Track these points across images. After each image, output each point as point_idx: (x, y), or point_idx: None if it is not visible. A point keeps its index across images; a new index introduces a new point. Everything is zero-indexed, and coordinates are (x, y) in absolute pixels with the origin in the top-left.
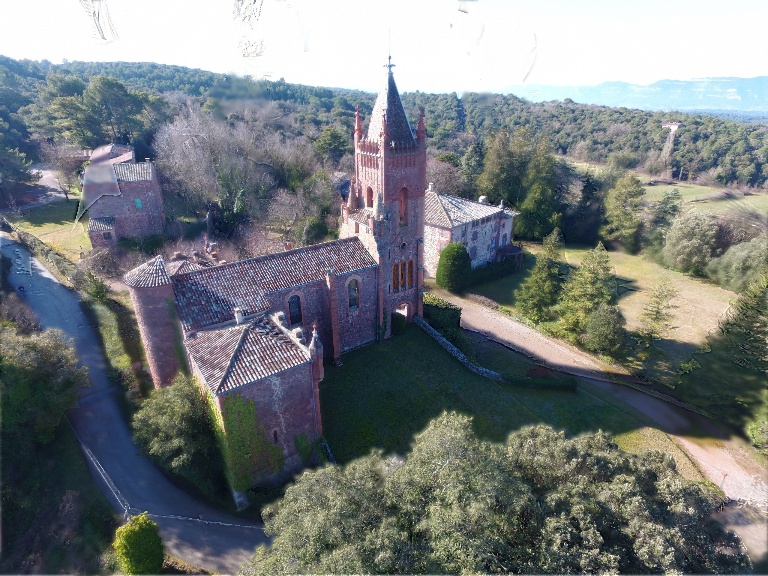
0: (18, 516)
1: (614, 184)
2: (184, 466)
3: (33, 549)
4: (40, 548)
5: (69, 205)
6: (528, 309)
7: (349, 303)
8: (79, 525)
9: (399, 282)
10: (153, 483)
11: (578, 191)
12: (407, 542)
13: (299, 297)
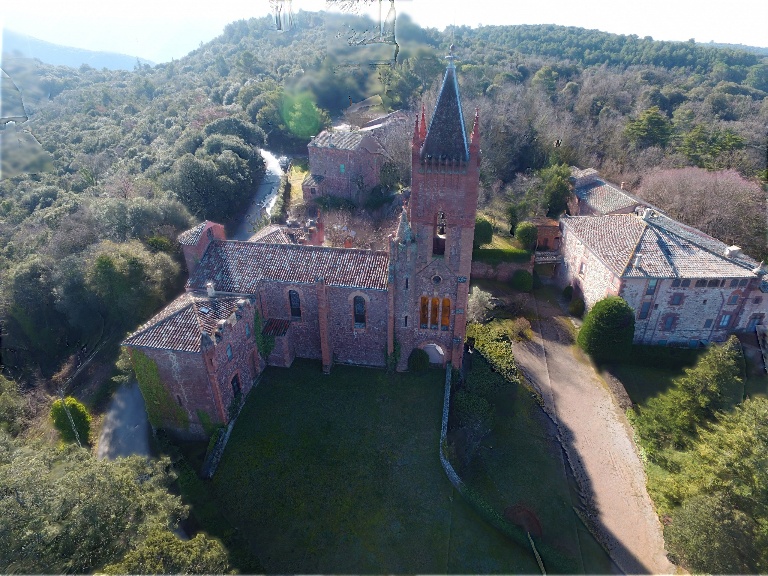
0: None
1: None
2: (129, 384)
3: (90, 386)
4: None
5: None
6: None
7: (356, 318)
8: (100, 386)
9: (428, 318)
10: None
11: None
12: None
13: (298, 293)
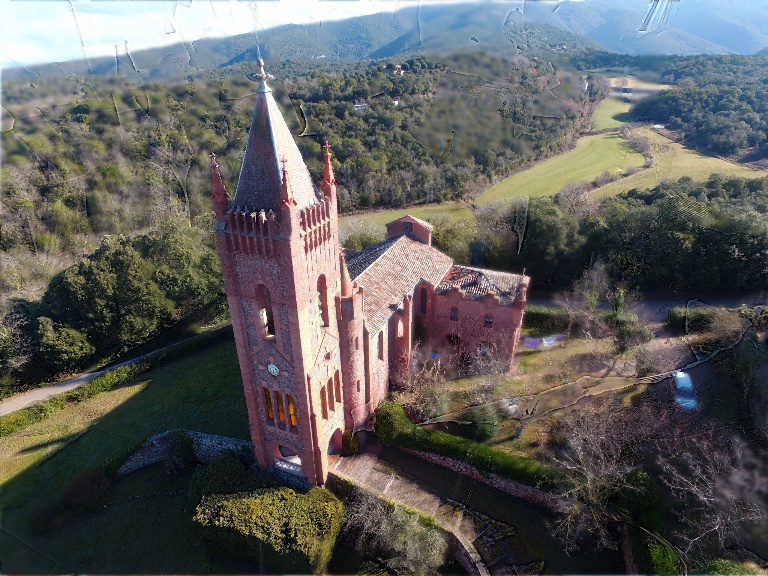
0: None
1: None
2: None
3: None
4: None
5: None
6: None
7: None
8: None
9: None
10: None
11: None
12: None
13: None
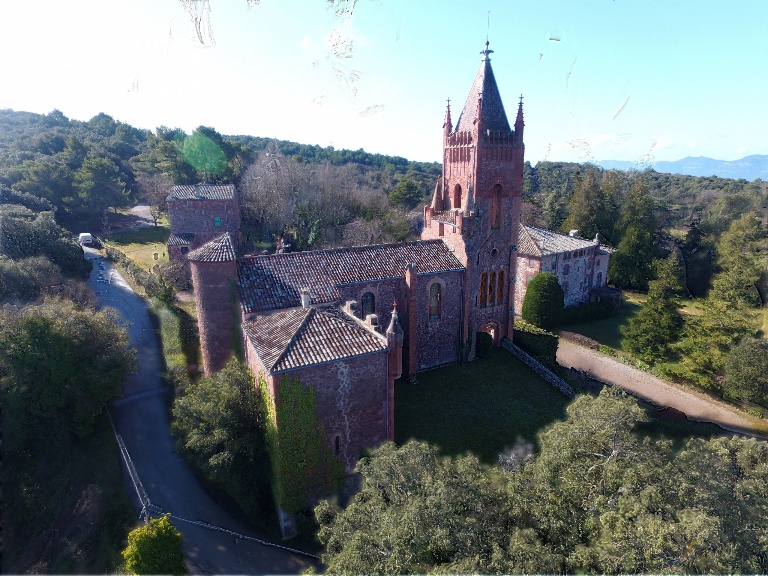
0: (38, 517)
1: (727, 227)
2: (224, 468)
3: (42, 556)
4: (50, 556)
5: (156, 230)
6: (638, 348)
7: (429, 311)
8: (96, 532)
9: (487, 295)
10: (188, 493)
11: (681, 237)
12: (561, 572)
13: (374, 295)
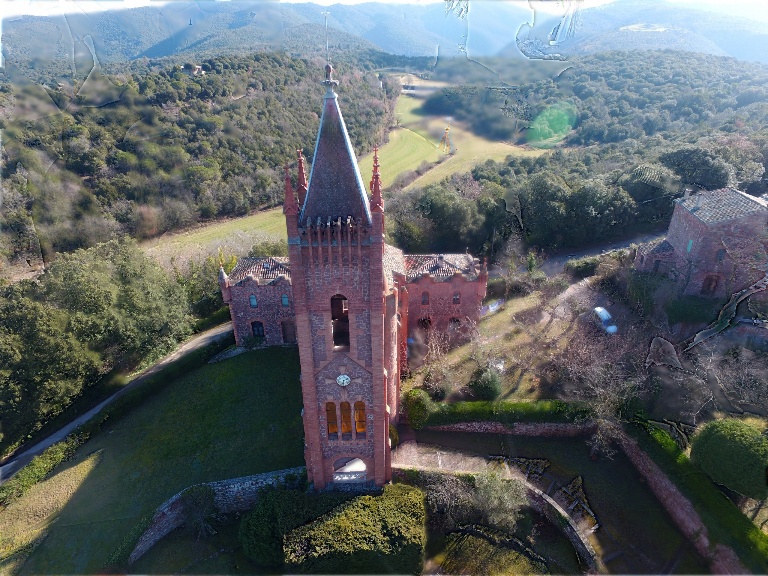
0: None
1: None
2: None
3: None
4: None
5: None
6: None
7: None
8: None
9: None
10: None
11: None
12: None
13: None
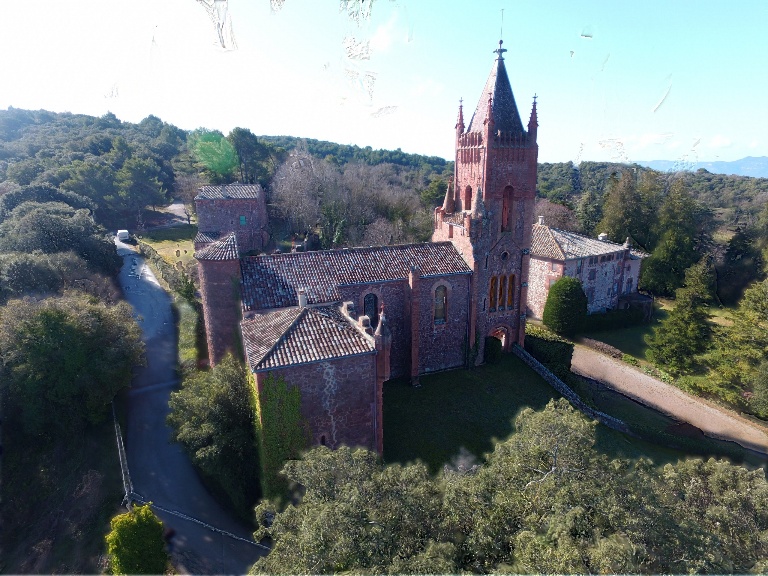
0: (50, 497)
1: None
2: (212, 461)
3: (47, 534)
4: (54, 535)
5: (189, 228)
6: (663, 359)
7: (435, 314)
8: (95, 515)
9: (497, 299)
10: (184, 483)
11: (725, 242)
12: None
13: (376, 296)
